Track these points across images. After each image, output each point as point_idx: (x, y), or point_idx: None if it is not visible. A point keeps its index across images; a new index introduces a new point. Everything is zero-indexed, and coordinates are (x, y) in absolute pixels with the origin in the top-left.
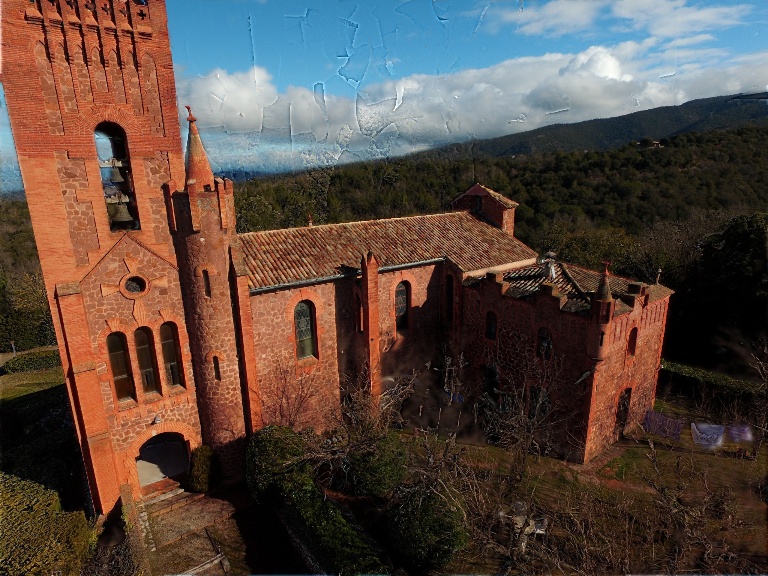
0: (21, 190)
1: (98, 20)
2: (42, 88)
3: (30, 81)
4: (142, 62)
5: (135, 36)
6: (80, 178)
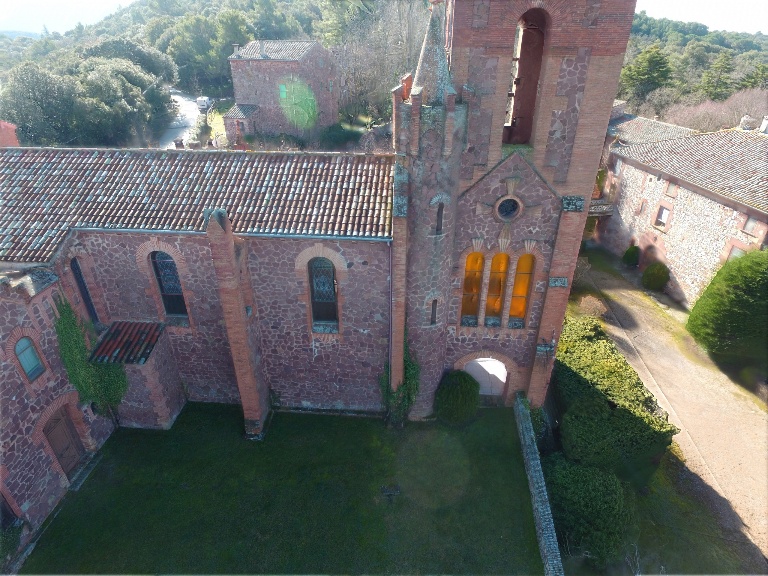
0: None
1: None
2: None
3: None
4: None
5: None
6: None
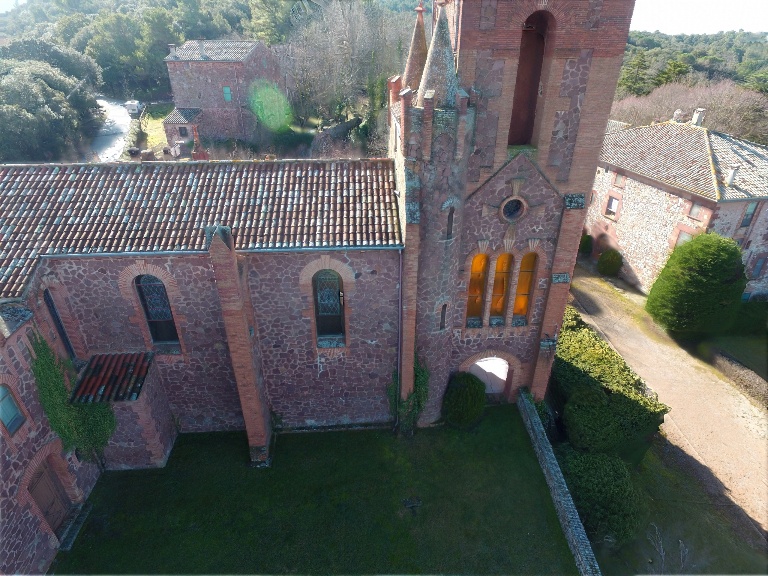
0: None
1: None
2: None
3: None
4: None
5: None
6: None
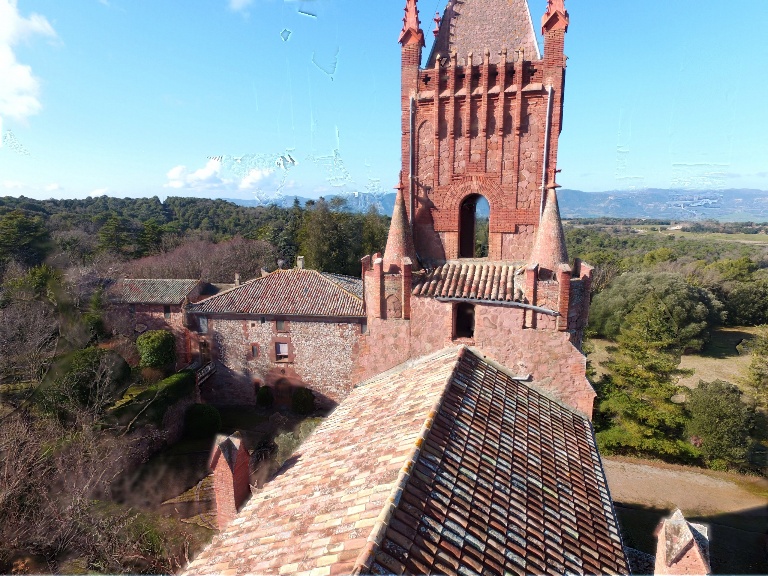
0: None
1: None
2: None
3: None
4: None
5: None
6: None
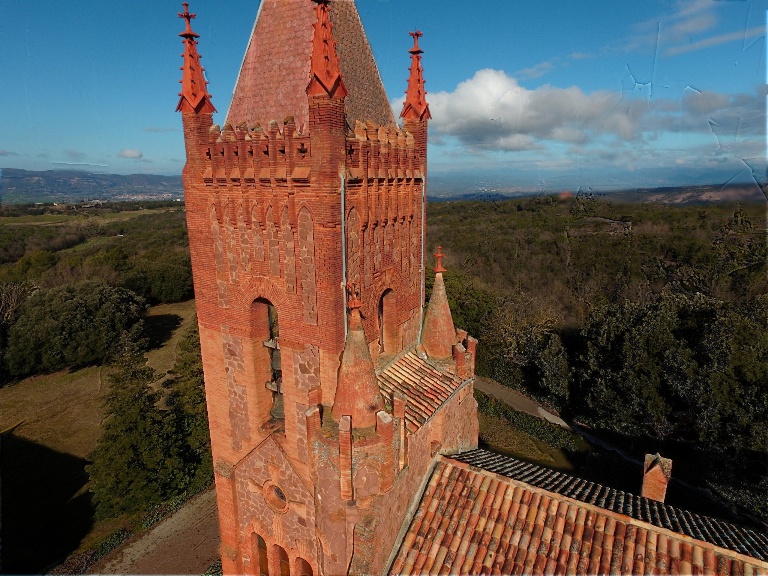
0: (553, 219)
1: (254, 171)
2: (216, 256)
3: (207, 249)
4: (300, 220)
5: (289, 185)
6: (239, 358)
